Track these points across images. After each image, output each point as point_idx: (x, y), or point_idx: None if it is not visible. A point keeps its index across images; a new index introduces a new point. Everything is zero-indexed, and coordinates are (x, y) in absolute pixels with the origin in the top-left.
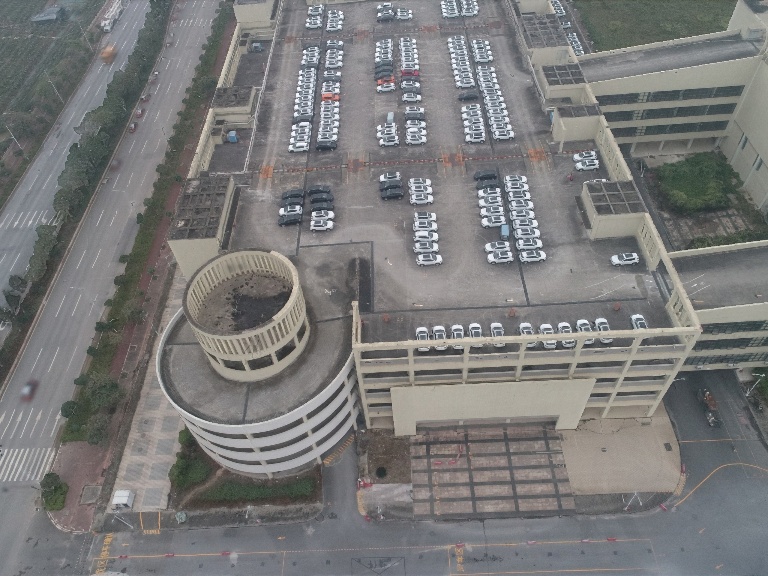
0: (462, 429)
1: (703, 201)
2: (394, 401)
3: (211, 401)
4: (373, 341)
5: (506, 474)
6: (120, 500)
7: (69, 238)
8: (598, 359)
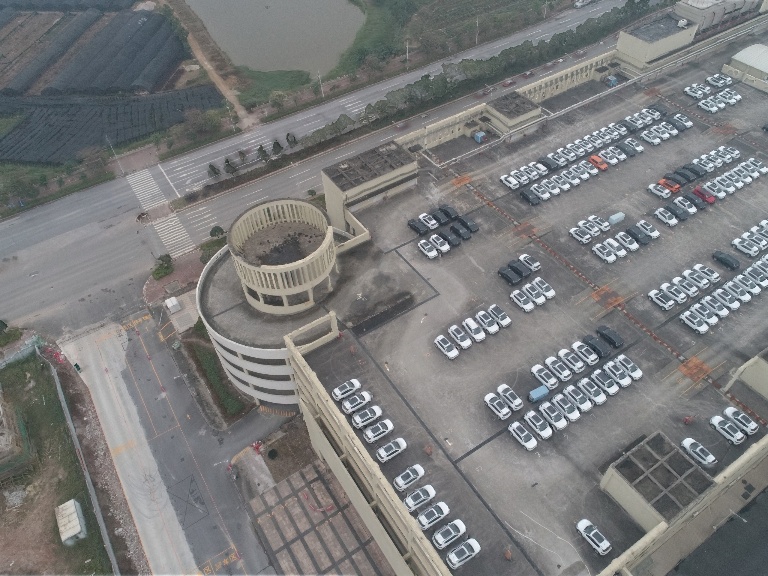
0: None
1: None
2: None
3: (221, 289)
4: (325, 355)
5: (326, 563)
6: (169, 303)
7: (356, 136)
8: None
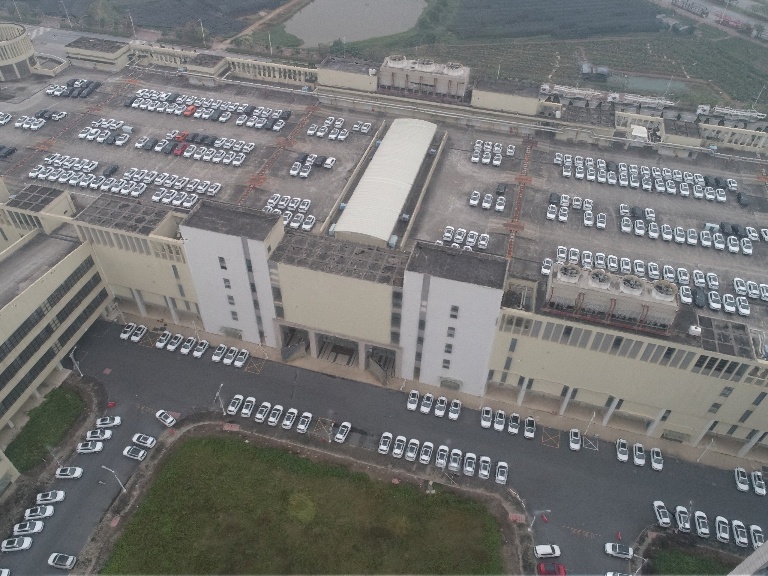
0: None
1: None
2: None
3: None
4: None
5: None
6: None
7: None
8: None
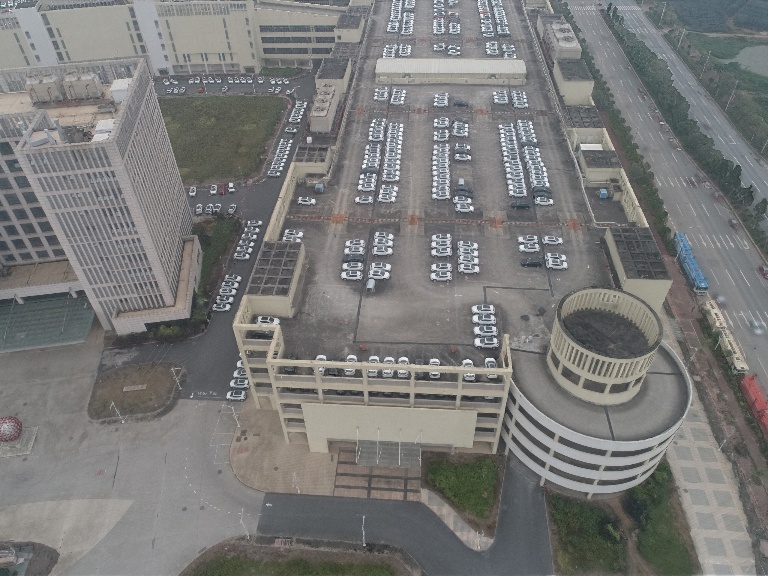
0: None
1: None
2: None
3: None
4: None
5: None
6: None
7: None
8: None
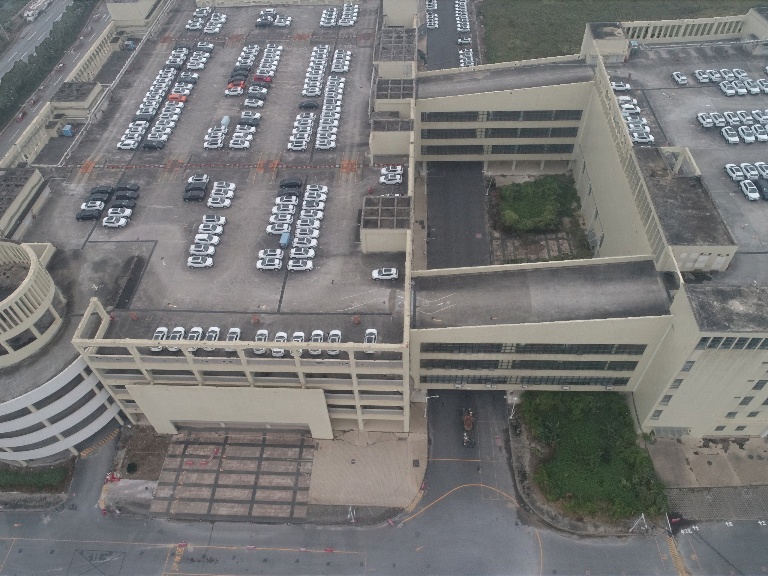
0: (223, 431)
1: (533, 223)
2: (136, 398)
3: None
4: (115, 338)
5: (251, 478)
6: None
7: None
8: (321, 370)
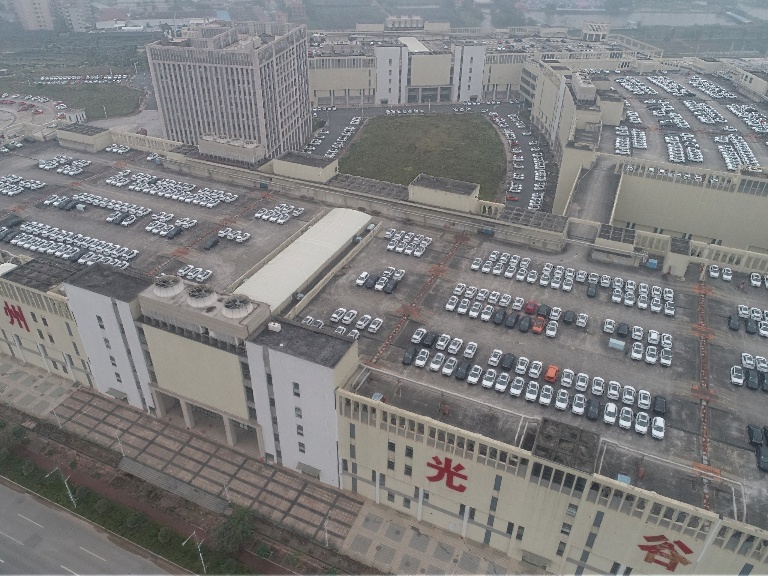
0: None
1: None
2: None
3: None
4: None
5: None
6: None
7: None
8: None
